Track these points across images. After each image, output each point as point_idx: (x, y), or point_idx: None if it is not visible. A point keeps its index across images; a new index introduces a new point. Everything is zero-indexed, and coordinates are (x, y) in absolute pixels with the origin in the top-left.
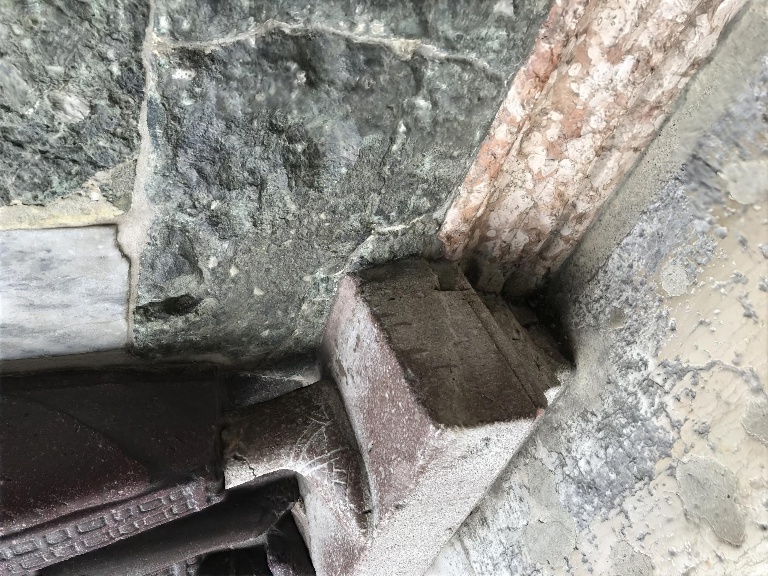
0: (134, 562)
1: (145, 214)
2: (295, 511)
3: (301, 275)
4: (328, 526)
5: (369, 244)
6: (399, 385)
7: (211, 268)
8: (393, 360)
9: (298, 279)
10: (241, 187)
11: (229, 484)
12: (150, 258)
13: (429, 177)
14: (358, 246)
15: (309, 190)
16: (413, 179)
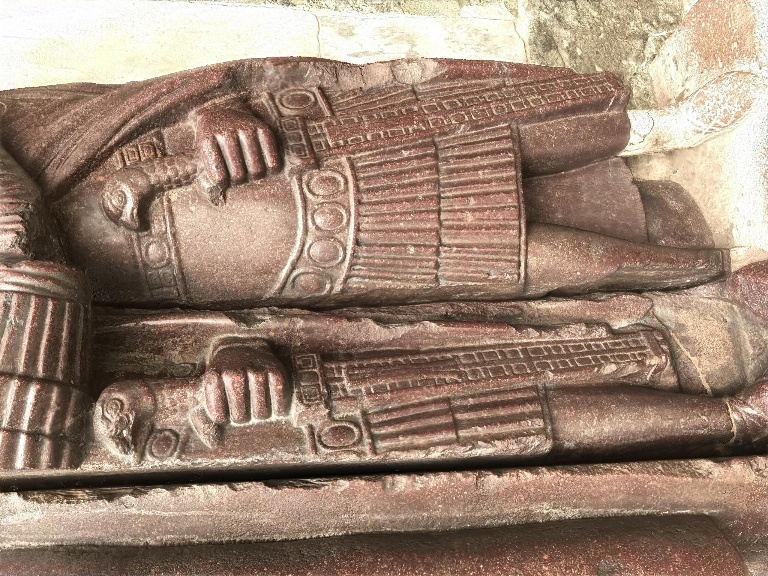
0: (593, 236)
1: (525, 19)
2: (735, 263)
3: (620, 59)
4: (755, 188)
5: (651, 44)
6: (701, 4)
7: (566, 47)
8: (691, 10)
9: (619, 62)
10: (565, 1)
11: (635, 120)
12: (533, 40)
13: (661, 3)
14: (645, 47)
15: (599, 4)
16: (653, 3)
